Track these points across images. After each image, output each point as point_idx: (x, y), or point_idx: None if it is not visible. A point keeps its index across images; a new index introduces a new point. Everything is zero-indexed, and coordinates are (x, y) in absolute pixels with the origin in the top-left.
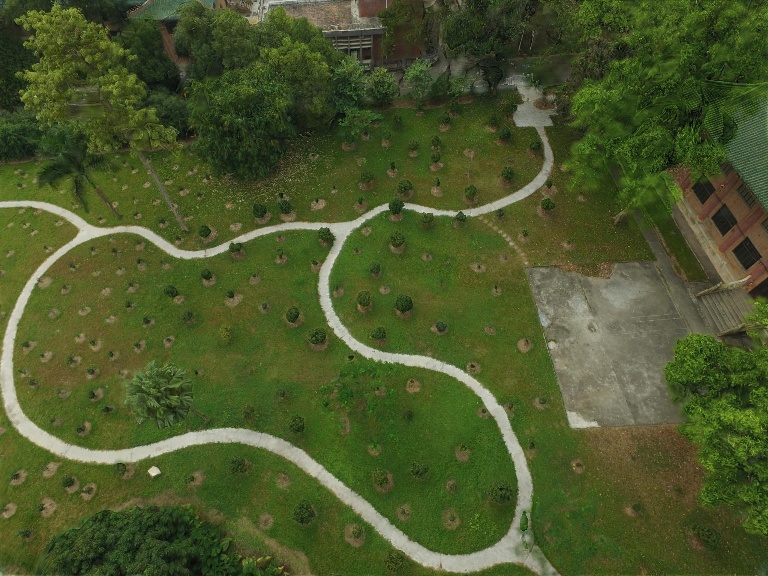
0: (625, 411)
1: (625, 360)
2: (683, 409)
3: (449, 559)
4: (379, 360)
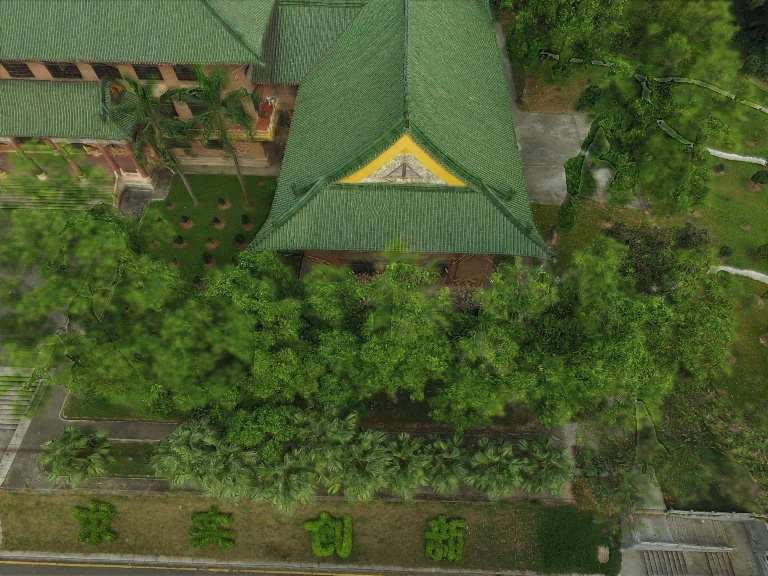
0: (579, 121)
1: (572, 144)
2: (540, 119)
3: (686, 81)
4: (759, 159)
